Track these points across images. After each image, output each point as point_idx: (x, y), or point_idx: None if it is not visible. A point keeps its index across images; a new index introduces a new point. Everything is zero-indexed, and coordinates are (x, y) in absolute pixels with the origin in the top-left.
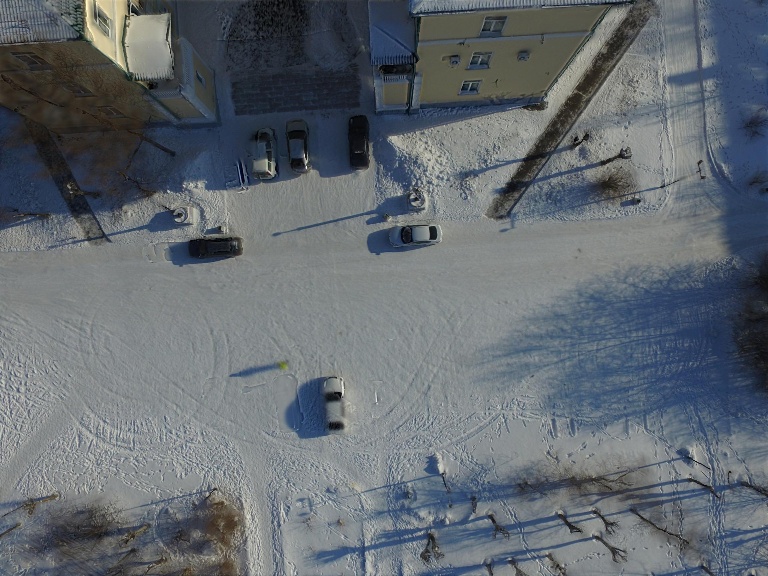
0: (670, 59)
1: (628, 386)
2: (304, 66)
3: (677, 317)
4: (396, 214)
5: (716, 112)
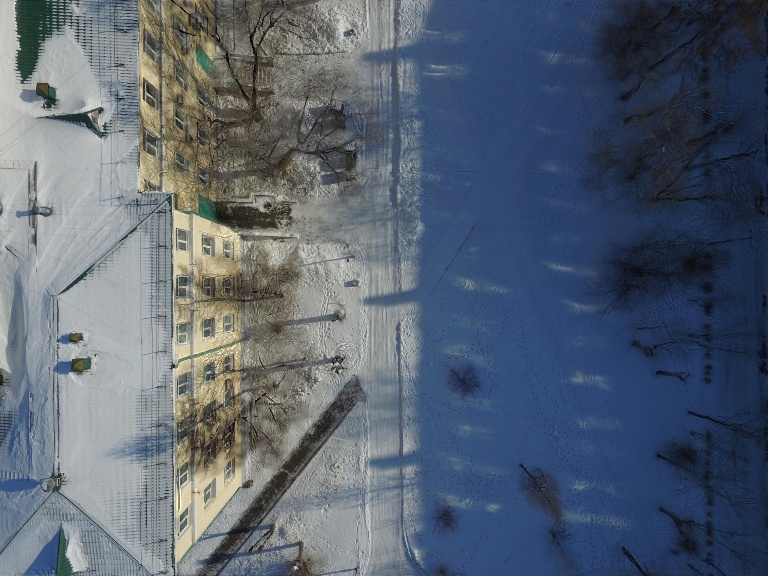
0: (373, 444)
1: None
2: None
3: None
4: None
5: (414, 499)
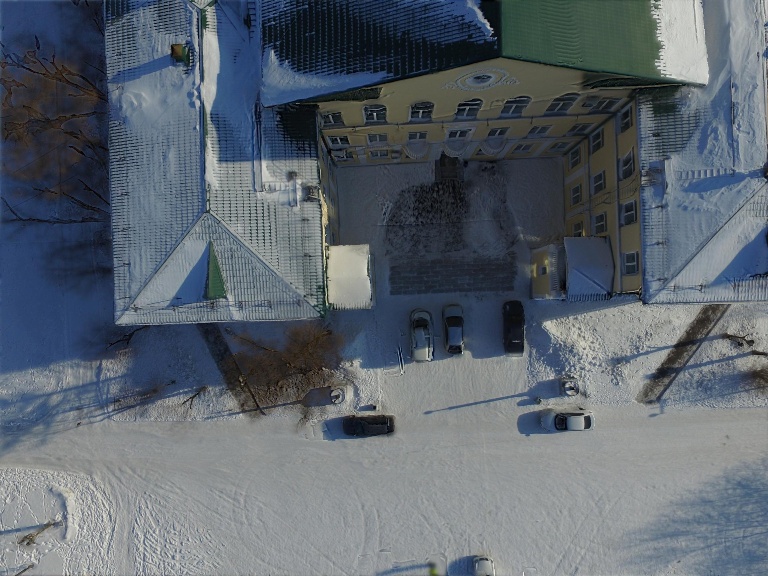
0: None
1: None
2: (462, 252)
3: None
4: (547, 397)
5: None
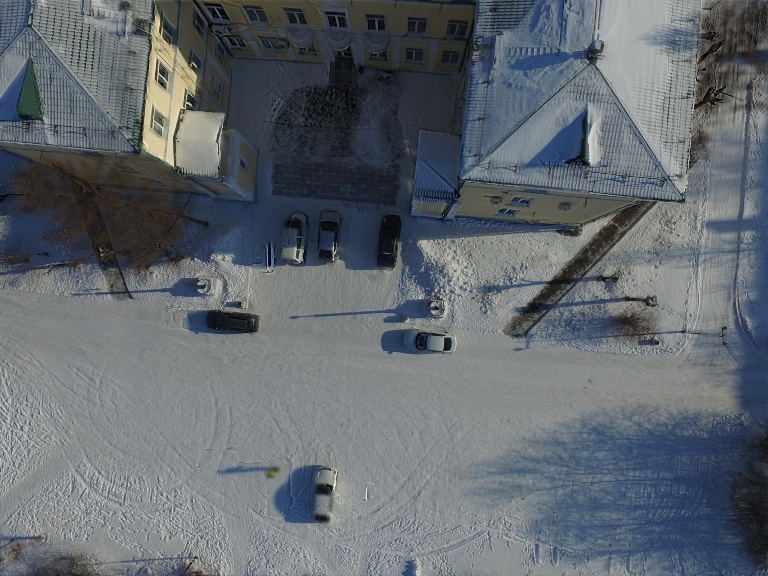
0: (711, 205)
1: (617, 524)
2: (347, 159)
3: (677, 463)
4: (414, 317)
5: (749, 265)
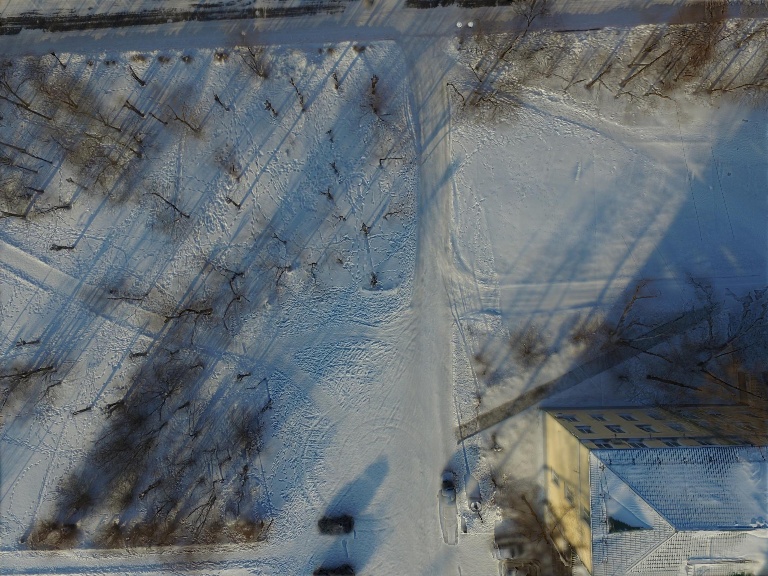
0: None
1: None
2: None
3: None
4: None
5: None
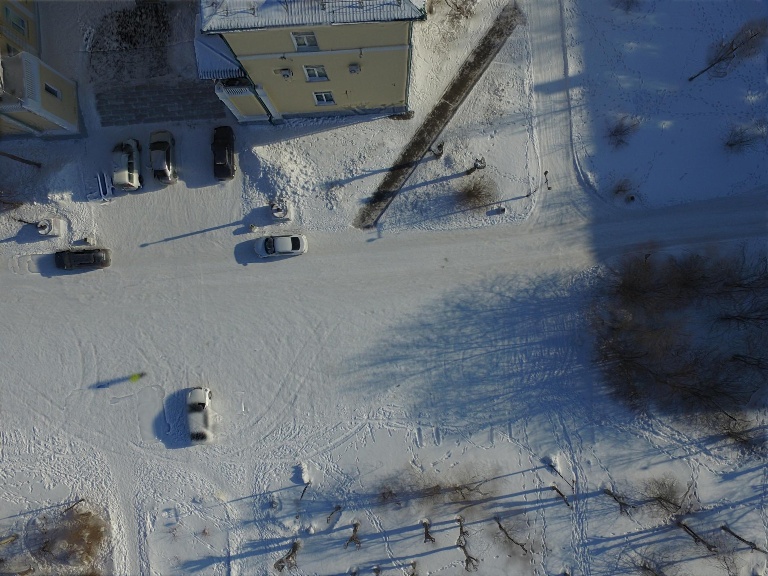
0: (537, 67)
1: (494, 395)
2: (167, 77)
3: (543, 326)
4: (262, 225)
5: (582, 120)
